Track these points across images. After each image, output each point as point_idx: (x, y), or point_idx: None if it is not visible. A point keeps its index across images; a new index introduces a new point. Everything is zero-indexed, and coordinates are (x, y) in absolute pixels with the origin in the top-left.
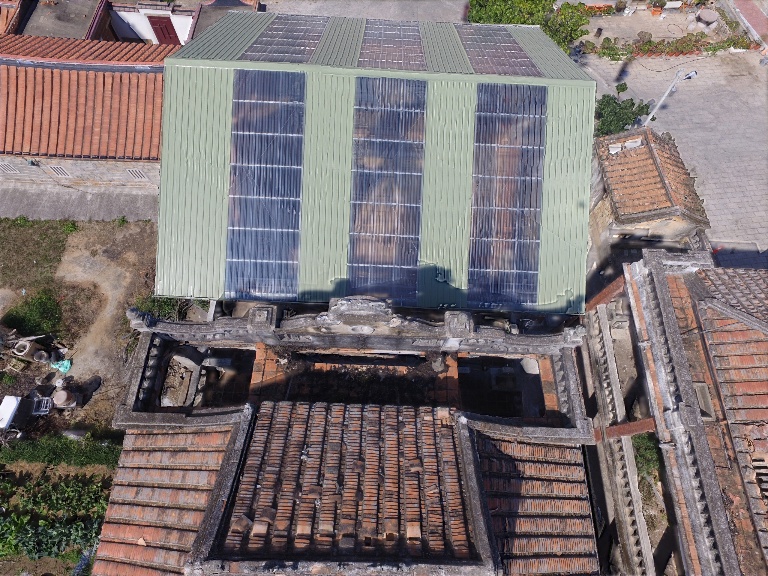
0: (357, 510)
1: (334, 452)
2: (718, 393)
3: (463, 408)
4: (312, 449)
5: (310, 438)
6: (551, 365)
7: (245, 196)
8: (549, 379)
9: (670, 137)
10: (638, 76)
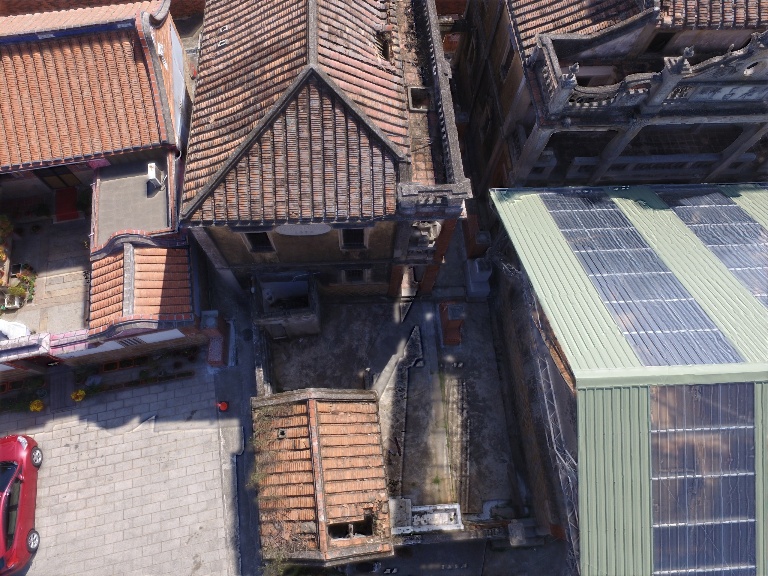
0: None
1: None
2: None
3: (561, 152)
4: None
5: None
6: None
7: None
8: None
9: (272, 564)
10: None
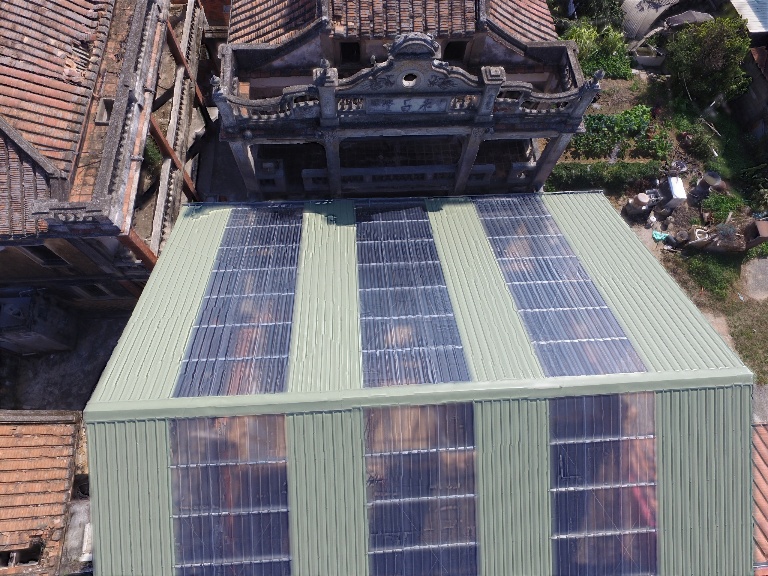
0: None
1: None
2: None
3: (308, 163)
4: None
5: None
6: None
7: (558, 257)
8: None
9: None
10: None
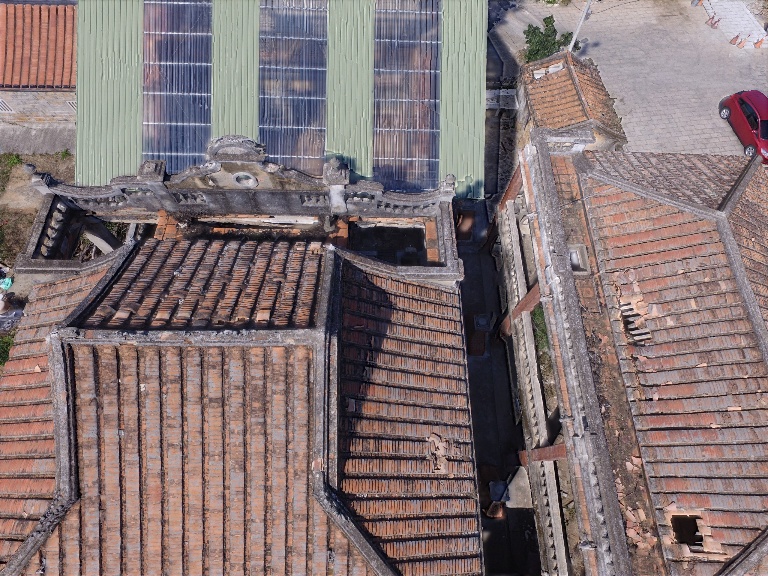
0: (216, 305)
1: (206, 270)
2: (594, 251)
3: None
4: (186, 268)
5: (186, 262)
6: (436, 226)
7: (159, 93)
8: (433, 237)
9: (592, 62)
10: (573, 18)
